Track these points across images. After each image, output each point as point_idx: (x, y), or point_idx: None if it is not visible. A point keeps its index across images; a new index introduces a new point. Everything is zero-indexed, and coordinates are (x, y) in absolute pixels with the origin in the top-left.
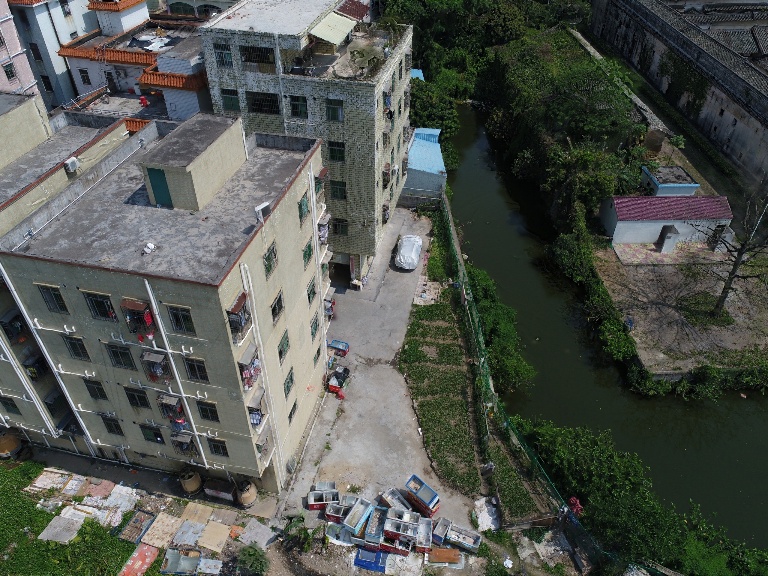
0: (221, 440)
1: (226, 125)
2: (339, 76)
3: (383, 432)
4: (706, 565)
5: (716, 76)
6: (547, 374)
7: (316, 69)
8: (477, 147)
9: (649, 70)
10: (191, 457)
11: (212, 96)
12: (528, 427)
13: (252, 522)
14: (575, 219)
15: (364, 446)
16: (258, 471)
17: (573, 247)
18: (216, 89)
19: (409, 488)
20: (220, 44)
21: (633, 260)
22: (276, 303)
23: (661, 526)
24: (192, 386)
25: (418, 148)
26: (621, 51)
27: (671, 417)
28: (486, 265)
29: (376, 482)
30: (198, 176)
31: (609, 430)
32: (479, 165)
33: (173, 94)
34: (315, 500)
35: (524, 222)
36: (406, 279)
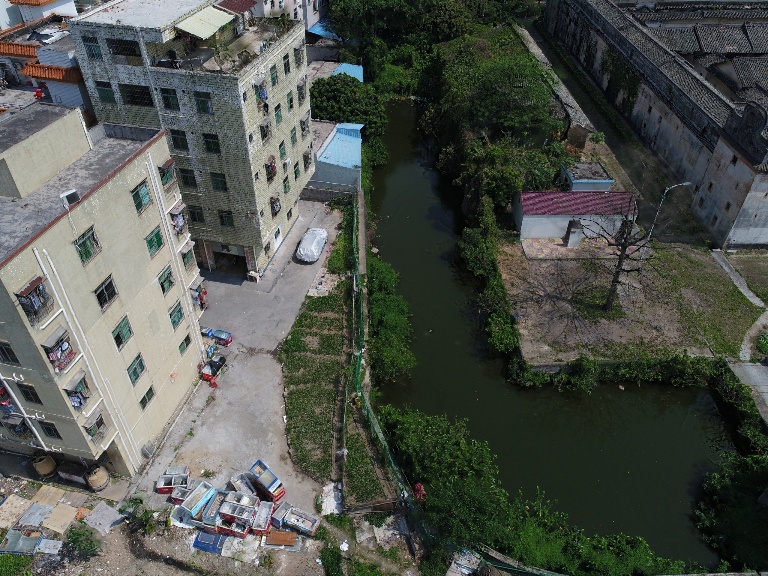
0: (50, 422)
1: (61, 115)
2: (205, 69)
3: (249, 419)
4: (537, 550)
5: (645, 73)
6: (434, 365)
7: (193, 62)
8: (411, 143)
9: (593, 67)
10: (26, 439)
11: (88, 88)
12: (396, 416)
13: (100, 505)
14: (482, 213)
15: (227, 433)
16: (92, 453)
17: (477, 241)
18: (91, 81)
19: (253, 472)
20: (88, 37)
21: (538, 254)
22: (104, 289)
23: (485, 510)
24: (7, 368)
25: (338, 143)
26: (571, 49)
27: (550, 408)
28: (397, 259)
29: (231, 467)
30: (17, 164)
31: (466, 419)
32: (409, 160)
33: (56, 86)
34: (164, 484)
35: (446, 217)
36: (305, 271)
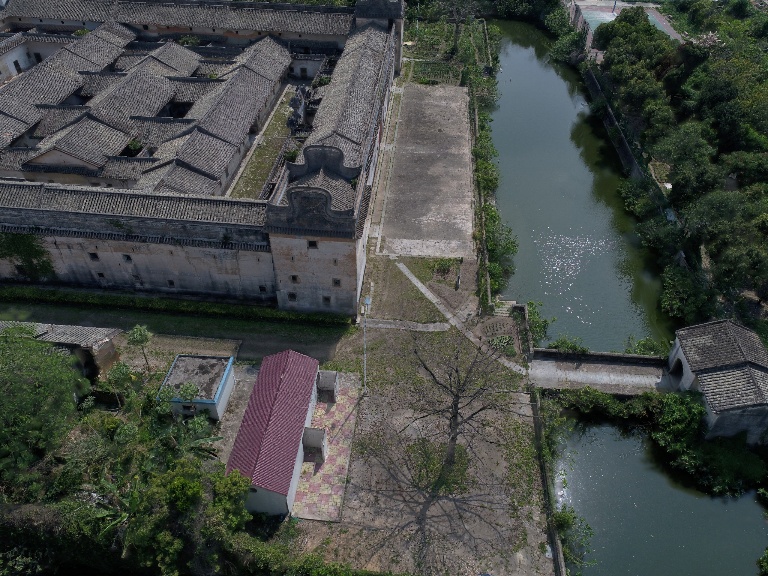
0: None
1: None
2: None
3: None
4: None
5: (40, 225)
6: None
7: None
8: None
9: None
10: None
11: None
12: None
13: None
14: (257, 559)
15: None
16: None
17: None
18: None
19: None
20: None
21: (333, 504)
22: None
23: None
24: None
25: None
26: None
27: None
28: None
29: None
30: None
31: None
32: None
33: None
34: None
35: None
36: None
